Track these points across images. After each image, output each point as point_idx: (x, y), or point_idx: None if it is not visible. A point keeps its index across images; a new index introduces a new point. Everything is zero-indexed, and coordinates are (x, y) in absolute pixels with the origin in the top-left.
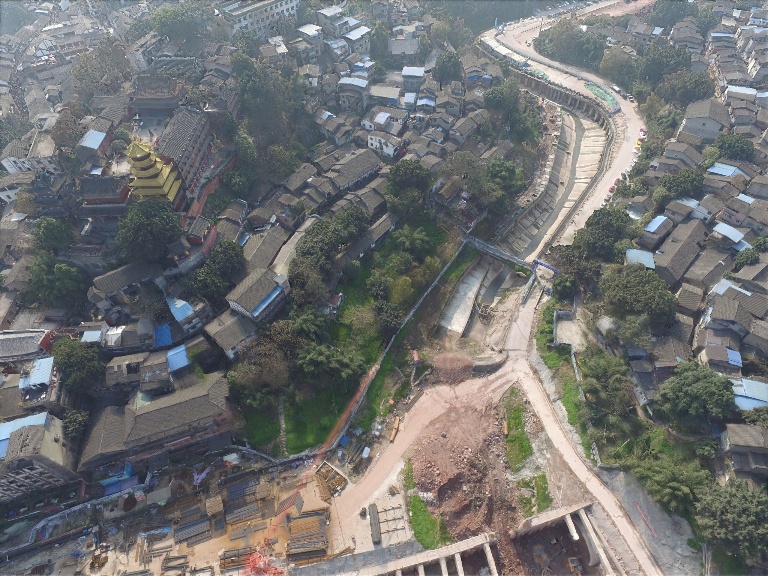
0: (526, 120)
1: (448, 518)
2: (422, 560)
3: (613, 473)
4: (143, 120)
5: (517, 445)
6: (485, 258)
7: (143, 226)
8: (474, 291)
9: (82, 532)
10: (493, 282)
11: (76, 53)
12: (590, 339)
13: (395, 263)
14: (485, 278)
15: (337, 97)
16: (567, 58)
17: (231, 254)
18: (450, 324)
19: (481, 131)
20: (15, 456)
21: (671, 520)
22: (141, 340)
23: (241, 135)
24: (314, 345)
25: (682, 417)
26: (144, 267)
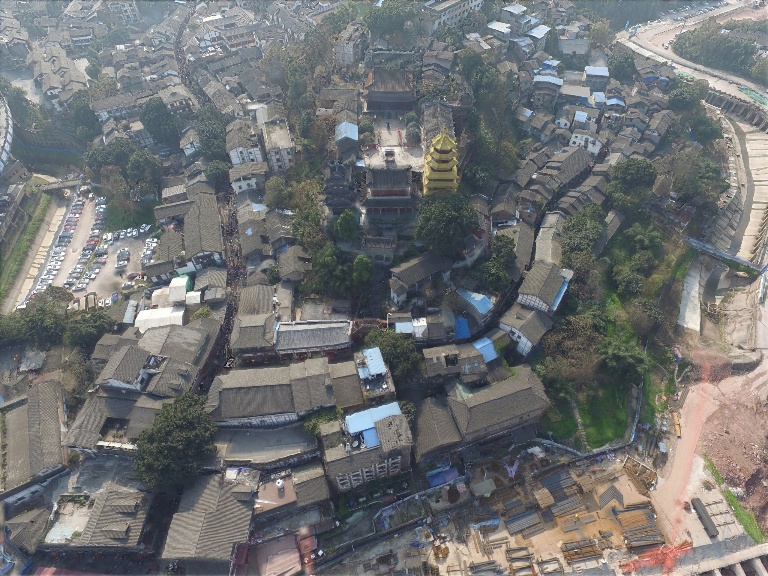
0: (712, 122)
1: (758, 513)
2: (758, 554)
3: None
4: (377, 113)
5: None
6: (696, 258)
7: (453, 219)
8: (696, 290)
9: (417, 523)
10: (708, 282)
11: (241, 45)
12: None
13: (638, 261)
14: (700, 277)
15: (530, 95)
16: (713, 62)
17: (511, 248)
18: (685, 322)
19: (671, 132)
20: (396, 445)
21: None
22: (446, 332)
23: (483, 130)
24: (609, 340)
25: None
26: (438, 260)
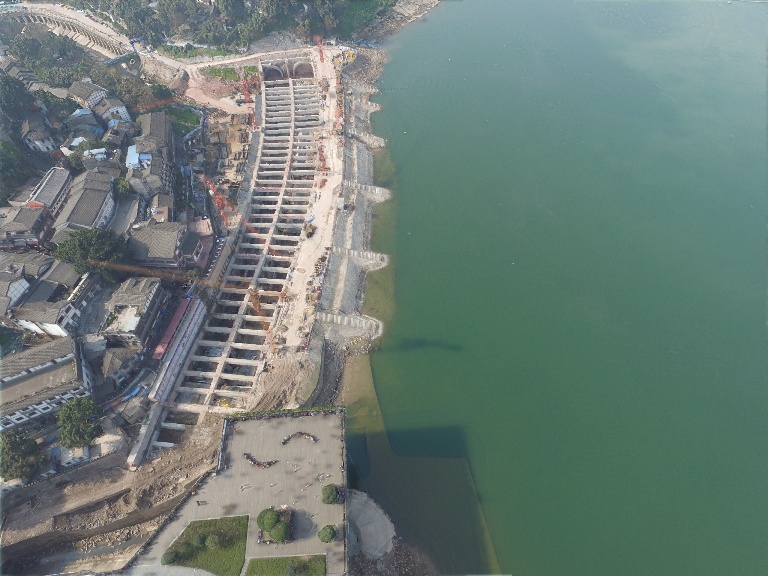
0: None
1: None
2: (264, 96)
3: (250, 48)
4: None
5: (228, 74)
6: None
7: None
8: None
9: (207, 186)
10: None
11: None
12: (188, 38)
13: None
14: None
15: None
16: None
17: None
18: None
19: None
20: (154, 142)
21: (271, 36)
22: None
23: None
24: None
25: (235, 10)
26: (33, 115)
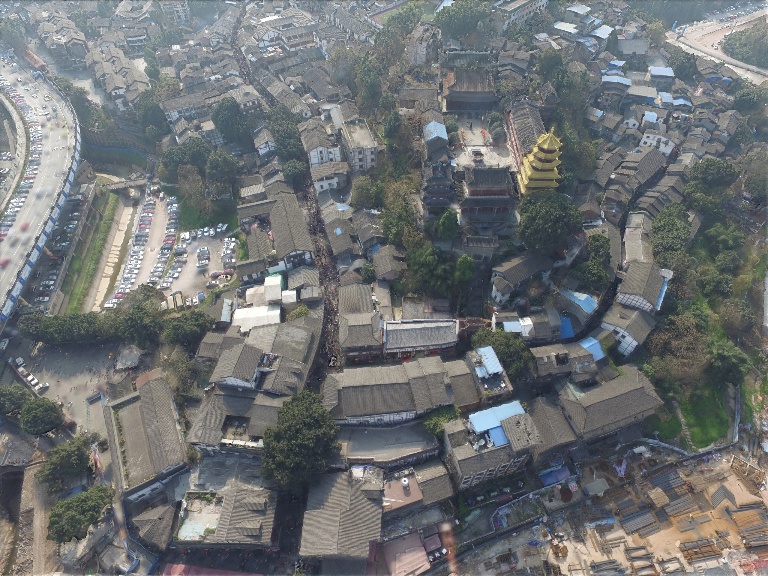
0: None
1: None
2: None
3: None
4: (458, 113)
5: None
6: None
7: (559, 218)
8: None
9: (534, 522)
10: None
11: (299, 45)
12: None
13: (723, 261)
14: None
15: (597, 95)
16: (766, 62)
17: (608, 248)
18: (767, 323)
19: (738, 132)
20: (527, 444)
21: None
22: (551, 332)
23: (567, 130)
24: (712, 340)
25: None
26: (540, 259)
